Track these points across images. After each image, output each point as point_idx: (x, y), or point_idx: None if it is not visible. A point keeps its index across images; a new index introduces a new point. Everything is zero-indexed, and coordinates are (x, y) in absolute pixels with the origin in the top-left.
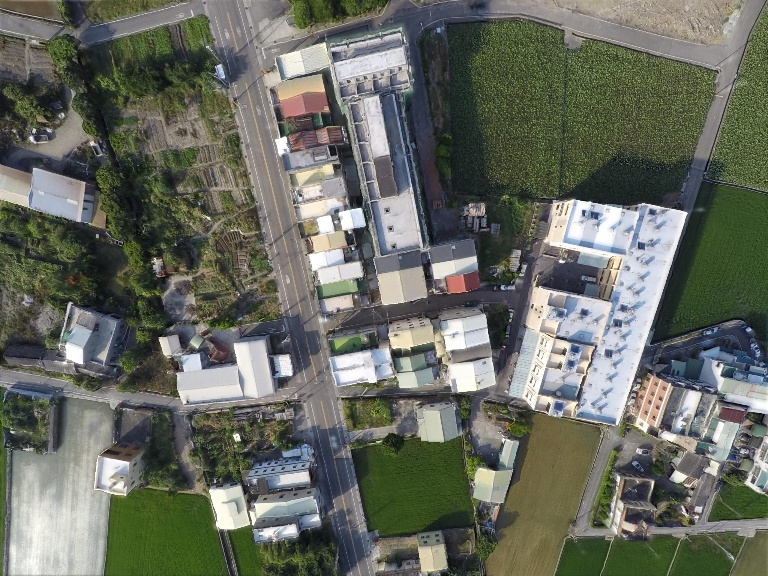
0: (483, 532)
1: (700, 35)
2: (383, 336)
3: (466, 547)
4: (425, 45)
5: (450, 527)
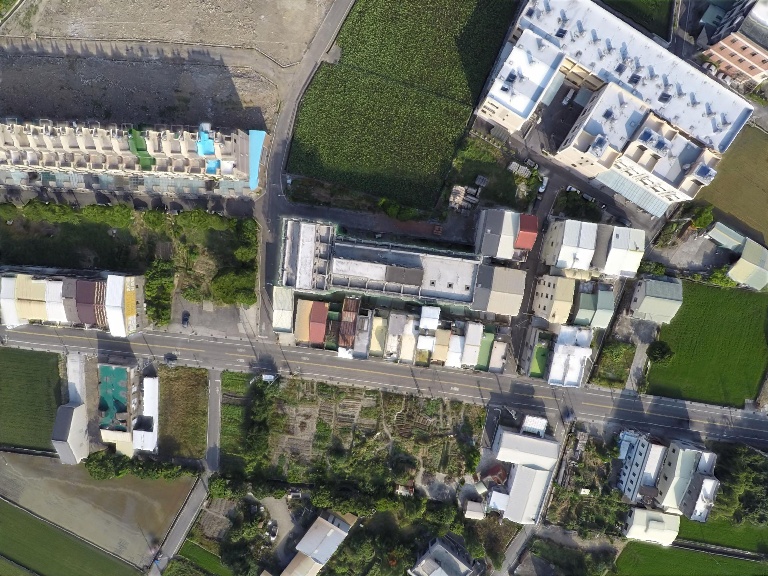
0: None
1: None
2: (544, 324)
3: None
4: (297, 197)
5: None
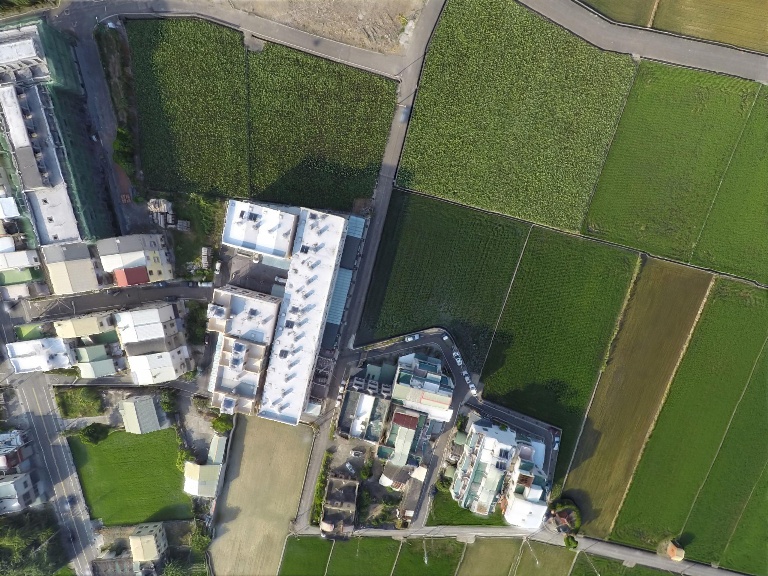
0: (201, 525)
1: (377, 44)
2: None
3: (188, 539)
4: (103, 39)
5: (172, 519)
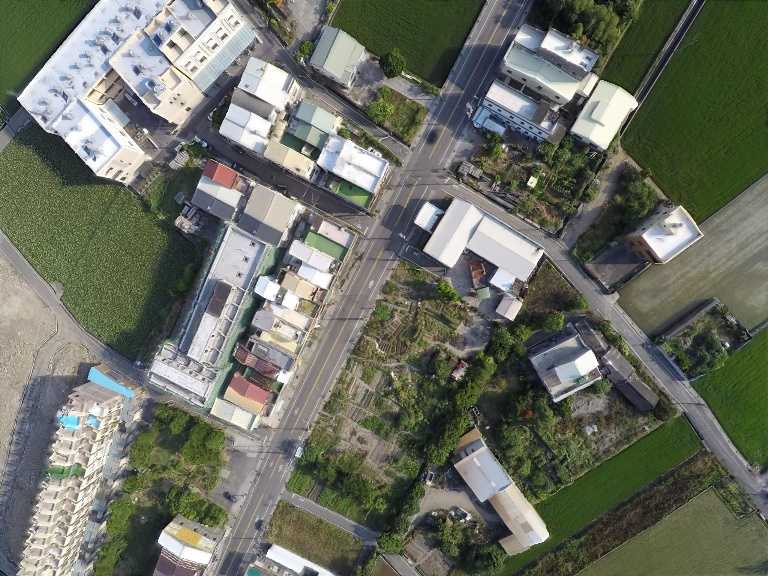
0: None
1: None
2: None
3: None
4: None
5: None
